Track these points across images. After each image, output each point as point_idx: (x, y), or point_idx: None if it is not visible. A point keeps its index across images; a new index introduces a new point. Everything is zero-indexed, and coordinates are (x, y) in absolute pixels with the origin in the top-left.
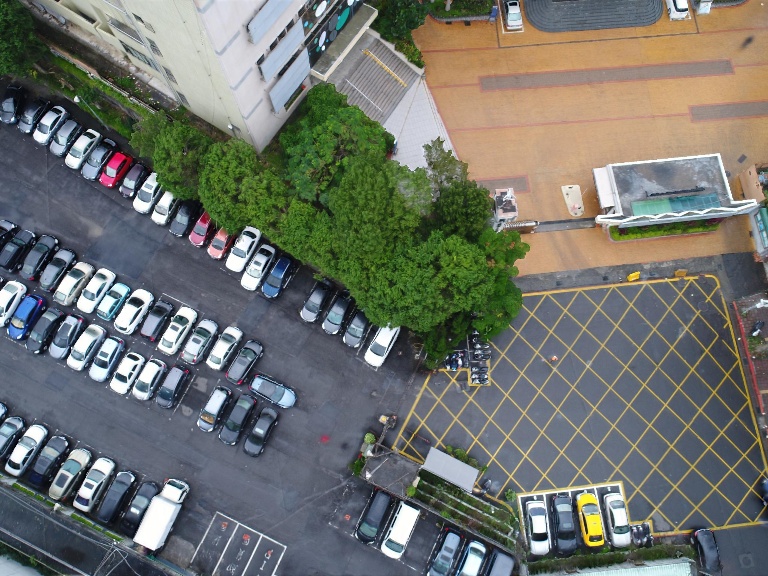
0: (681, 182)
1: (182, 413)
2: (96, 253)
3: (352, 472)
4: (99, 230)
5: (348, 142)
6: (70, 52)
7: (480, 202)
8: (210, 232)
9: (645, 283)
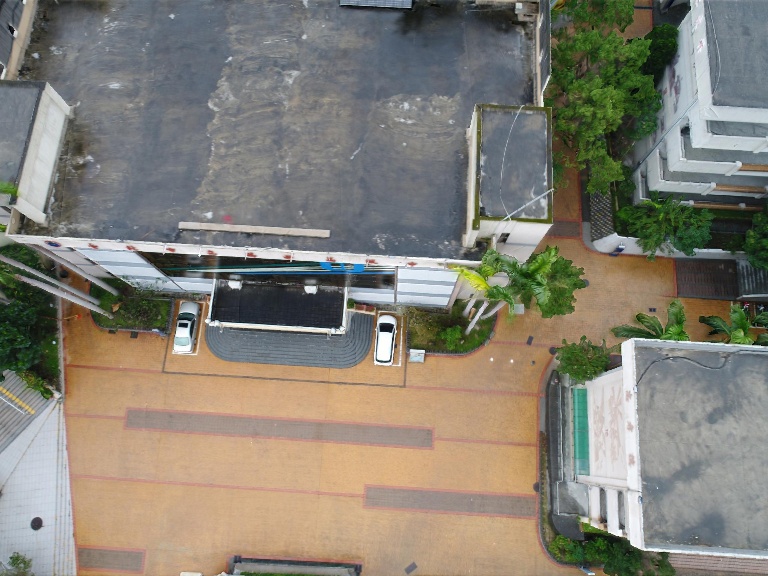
0: None
1: None
2: None
3: None
4: None
5: None
6: None
7: None
8: None
9: None
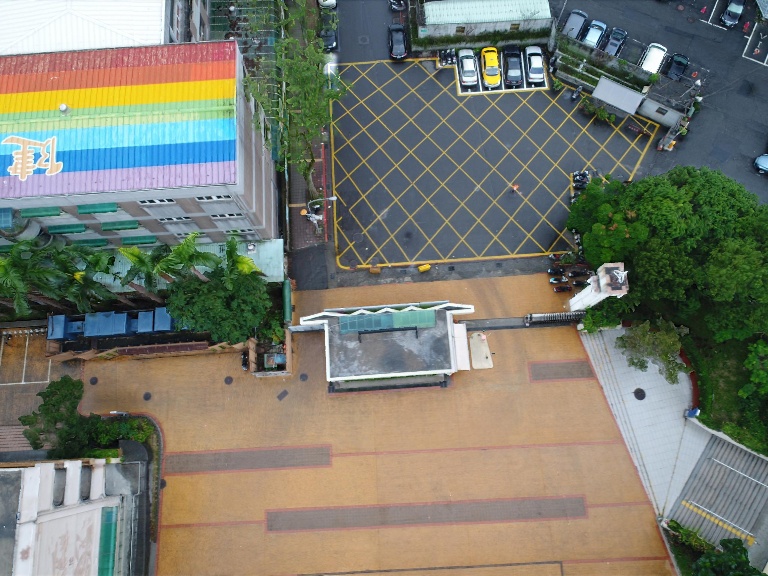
0: (377, 348)
1: None
2: None
3: None
4: None
5: None
6: None
7: (657, 263)
8: None
9: (412, 262)
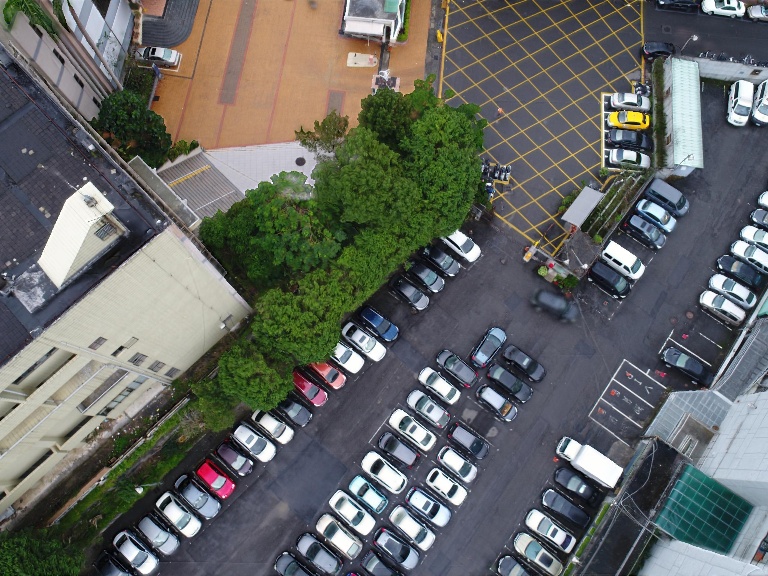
0: None
1: (494, 437)
2: (308, 511)
3: (569, 293)
4: (281, 506)
5: (292, 199)
6: (56, 508)
7: (389, 96)
8: (315, 384)
9: (446, 31)
